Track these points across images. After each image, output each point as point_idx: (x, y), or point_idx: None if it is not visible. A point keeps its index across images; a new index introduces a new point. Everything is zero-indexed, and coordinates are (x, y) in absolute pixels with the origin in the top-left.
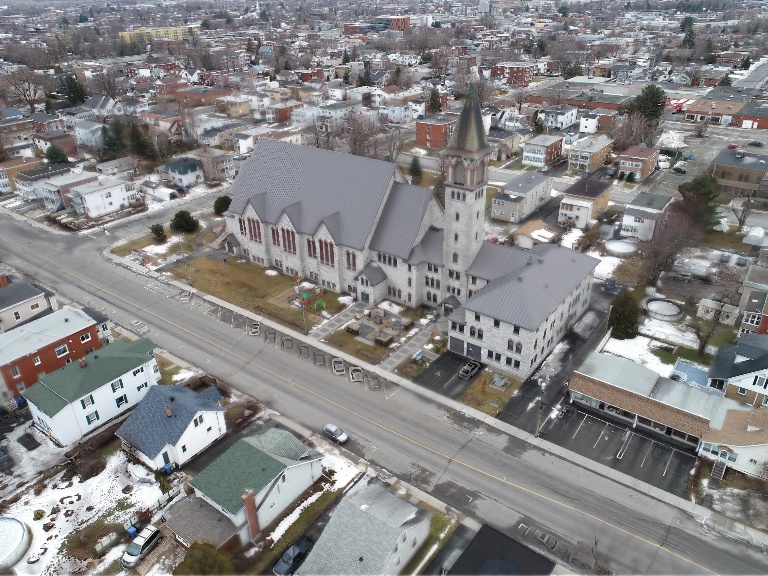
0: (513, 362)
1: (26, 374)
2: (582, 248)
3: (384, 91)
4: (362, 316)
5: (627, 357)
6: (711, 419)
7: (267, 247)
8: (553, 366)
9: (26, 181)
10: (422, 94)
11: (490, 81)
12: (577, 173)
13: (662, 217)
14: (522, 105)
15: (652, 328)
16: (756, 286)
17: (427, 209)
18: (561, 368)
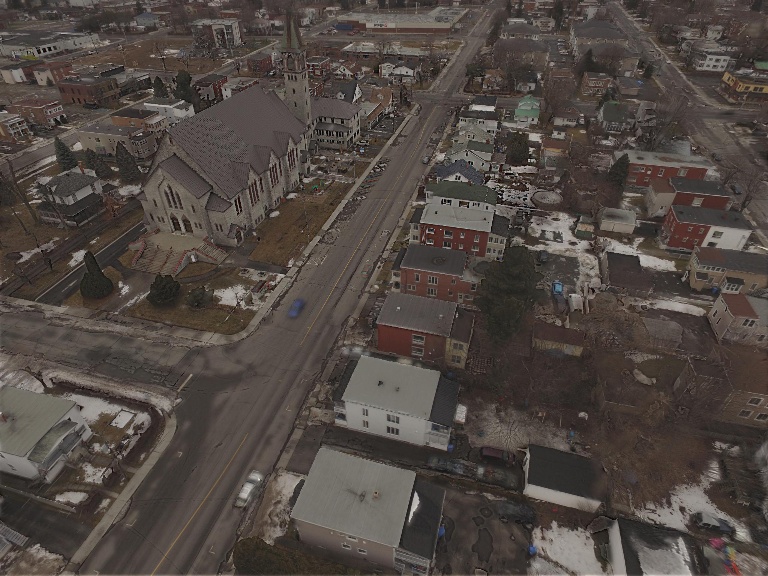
0: None
1: None
2: None
3: None
4: None
5: None
6: None
7: None
8: None
9: None
10: None
11: None
12: None
13: None
14: None
15: None
16: None
17: None
18: None
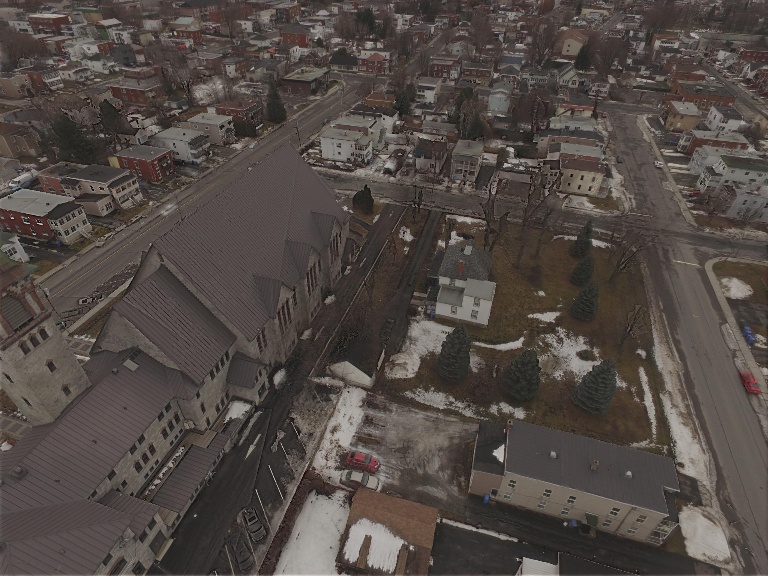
0: None
1: (8, 220)
2: None
3: None
4: None
5: None
6: None
7: None
8: None
9: (348, 112)
10: None
11: None
12: None
13: None
14: None
15: None
16: None
17: (117, 323)
18: None
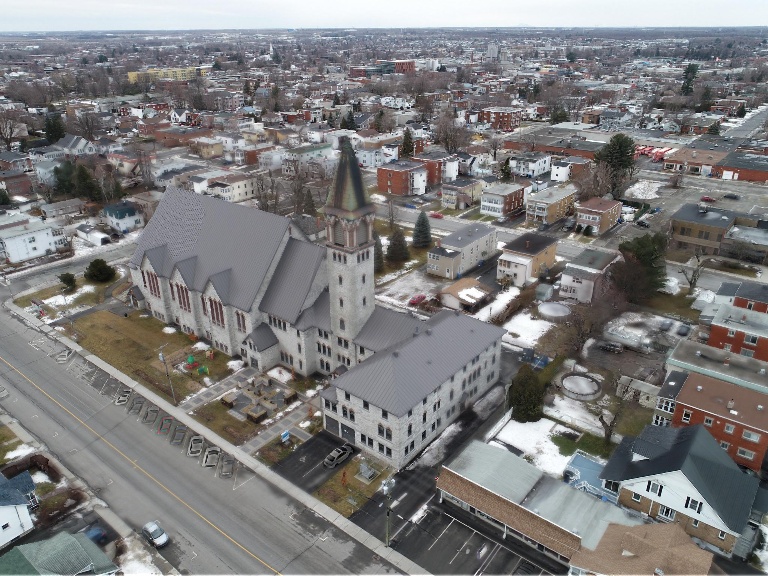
0: (385, 449)
1: None
2: (510, 310)
3: (360, 135)
4: (245, 385)
5: (522, 445)
6: (587, 535)
7: (166, 302)
8: (435, 454)
9: None
10: (399, 138)
11: (463, 127)
12: (534, 225)
13: (603, 278)
14: (500, 151)
15: (561, 409)
16: (680, 364)
17: (320, 269)
18: (444, 456)
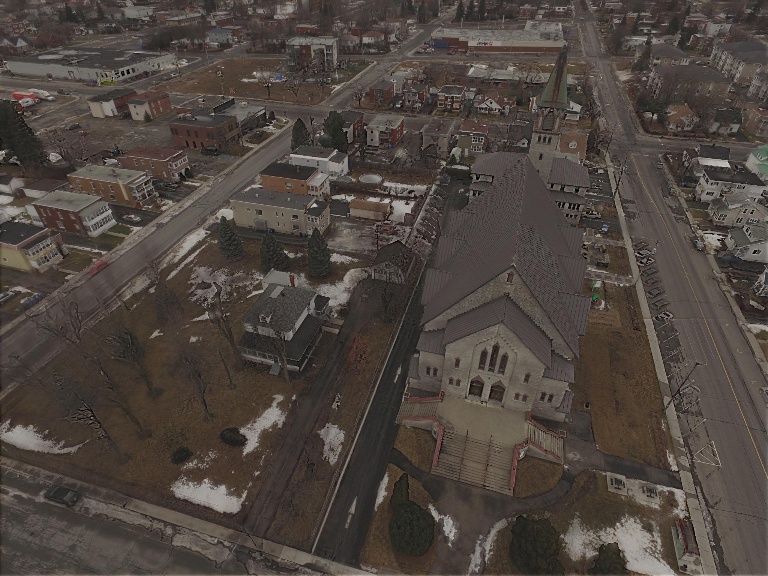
0: None
1: None
2: None
3: None
4: None
5: None
6: None
7: None
8: None
9: None
10: None
11: None
12: None
13: None
14: None
15: None
16: None
17: None
18: None
